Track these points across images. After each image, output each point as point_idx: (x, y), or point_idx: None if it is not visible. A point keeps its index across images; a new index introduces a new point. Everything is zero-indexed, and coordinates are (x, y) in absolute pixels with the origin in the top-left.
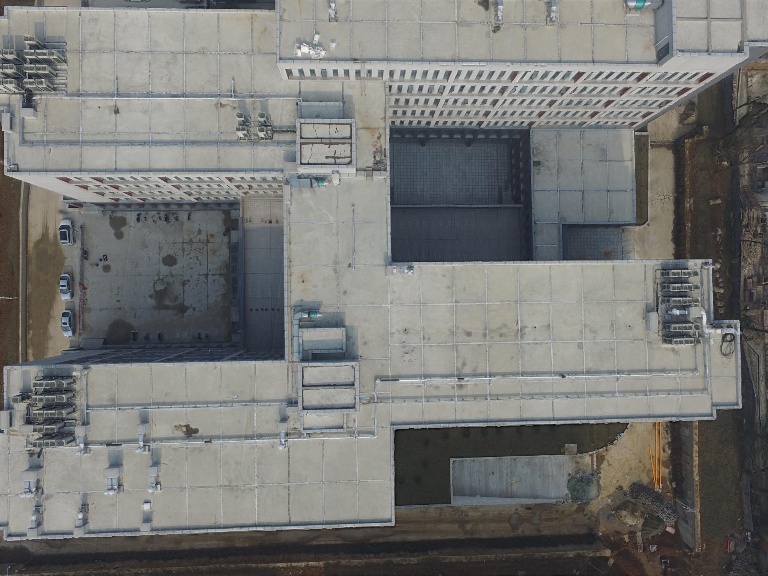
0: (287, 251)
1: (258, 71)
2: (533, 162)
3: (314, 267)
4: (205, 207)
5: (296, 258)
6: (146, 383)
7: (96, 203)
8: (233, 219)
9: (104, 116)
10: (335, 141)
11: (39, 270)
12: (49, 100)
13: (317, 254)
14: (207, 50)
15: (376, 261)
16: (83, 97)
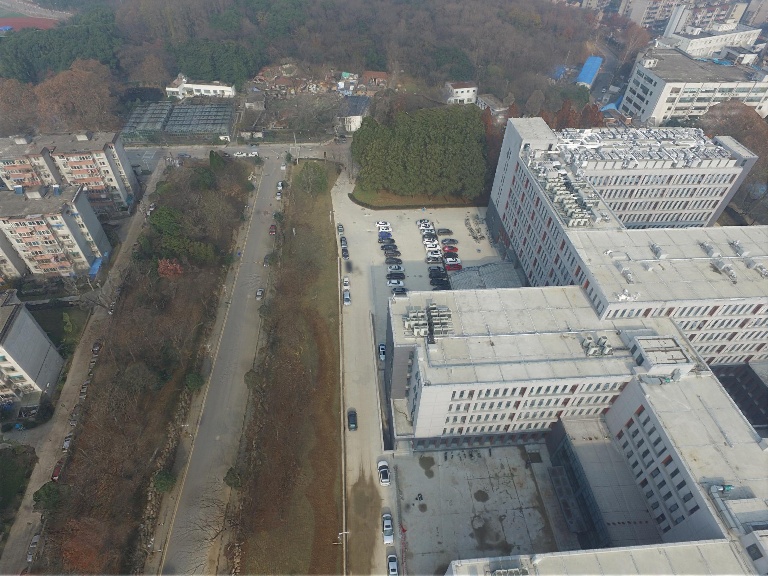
0: (668, 434)
1: (580, 317)
2: (767, 386)
3: (697, 447)
4: (503, 443)
5: (677, 440)
6: (597, 575)
7: (420, 440)
8: (529, 453)
9: (484, 348)
10: (668, 349)
11: (357, 514)
12: (443, 340)
13: (693, 436)
14: (542, 307)
15: (746, 439)
16: (468, 337)
